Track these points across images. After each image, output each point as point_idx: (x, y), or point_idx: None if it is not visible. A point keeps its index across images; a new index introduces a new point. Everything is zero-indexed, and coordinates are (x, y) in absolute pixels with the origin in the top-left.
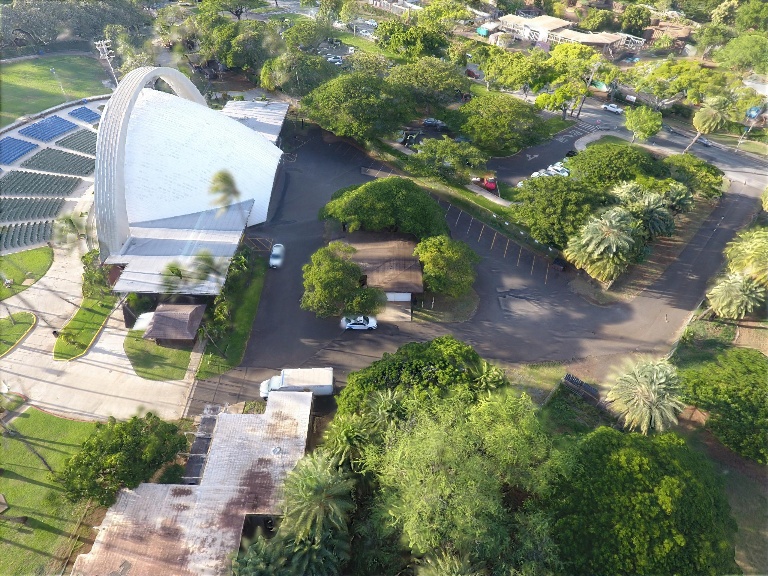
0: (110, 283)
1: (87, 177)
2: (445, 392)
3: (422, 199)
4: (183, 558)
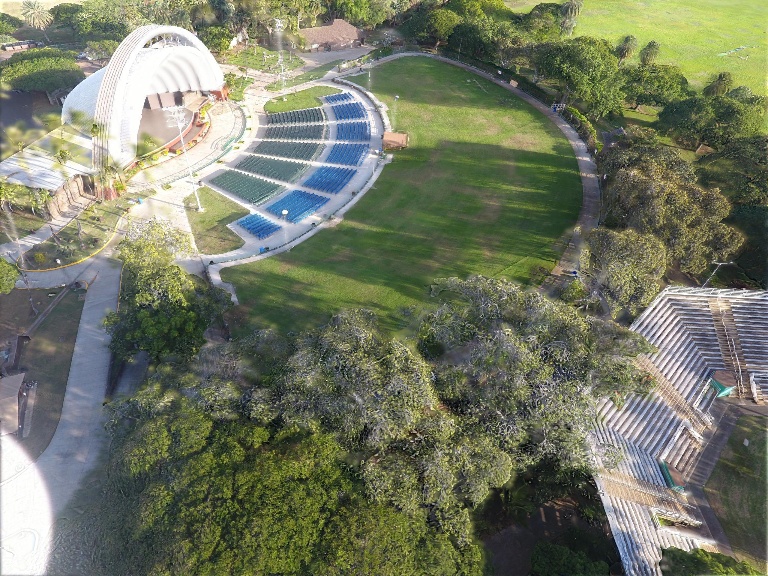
0: None
1: None
2: None
3: None
4: None
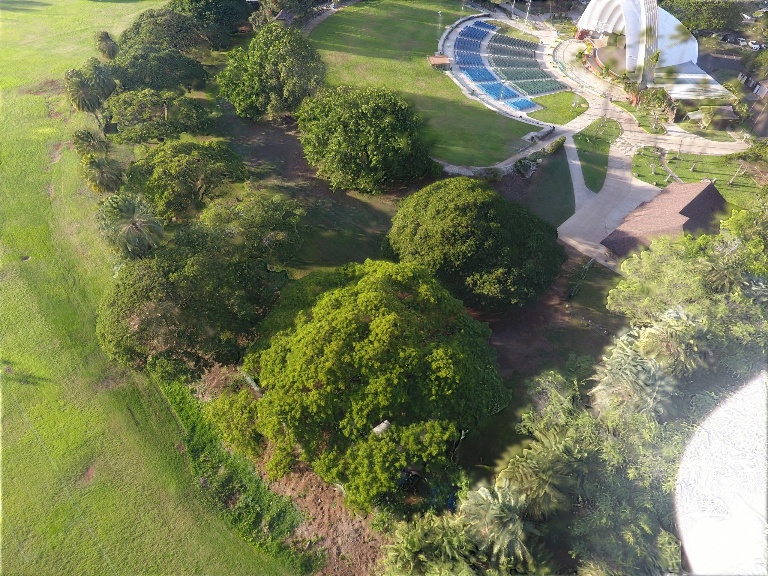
0: (645, 102)
1: (536, 59)
2: None
3: None
4: None
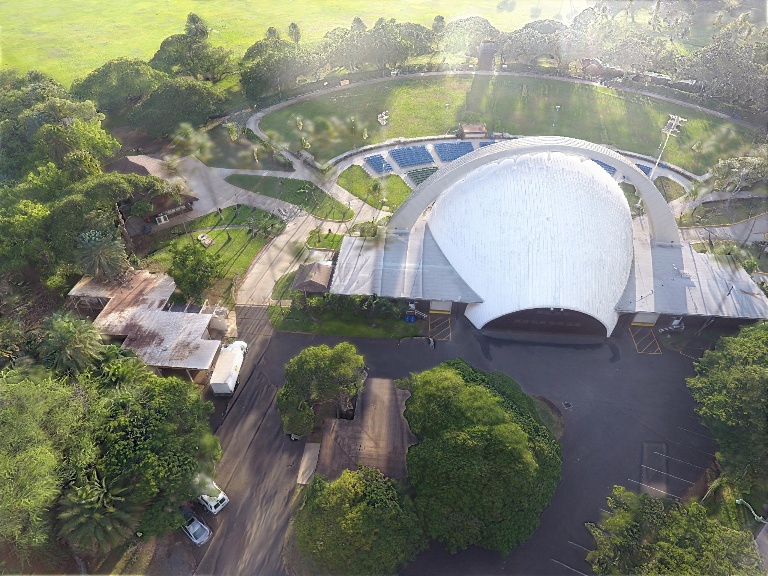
0: None
1: None
2: (108, 446)
3: (468, 476)
4: (119, 310)
